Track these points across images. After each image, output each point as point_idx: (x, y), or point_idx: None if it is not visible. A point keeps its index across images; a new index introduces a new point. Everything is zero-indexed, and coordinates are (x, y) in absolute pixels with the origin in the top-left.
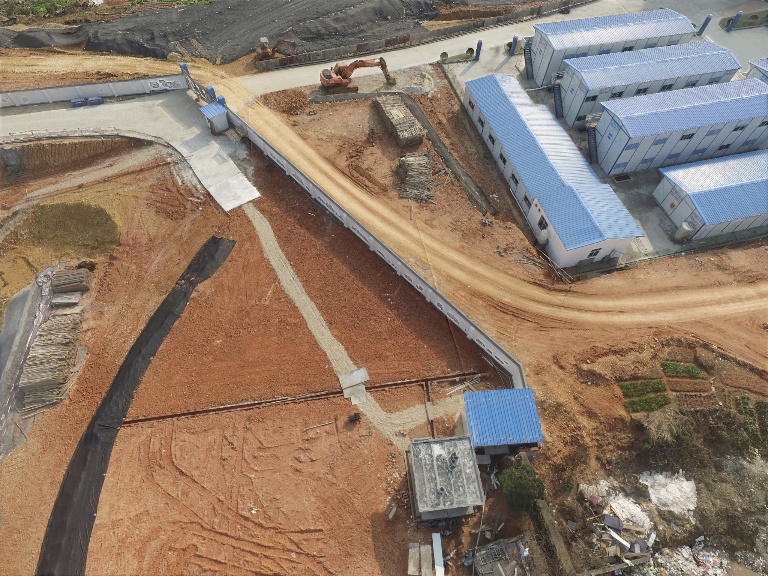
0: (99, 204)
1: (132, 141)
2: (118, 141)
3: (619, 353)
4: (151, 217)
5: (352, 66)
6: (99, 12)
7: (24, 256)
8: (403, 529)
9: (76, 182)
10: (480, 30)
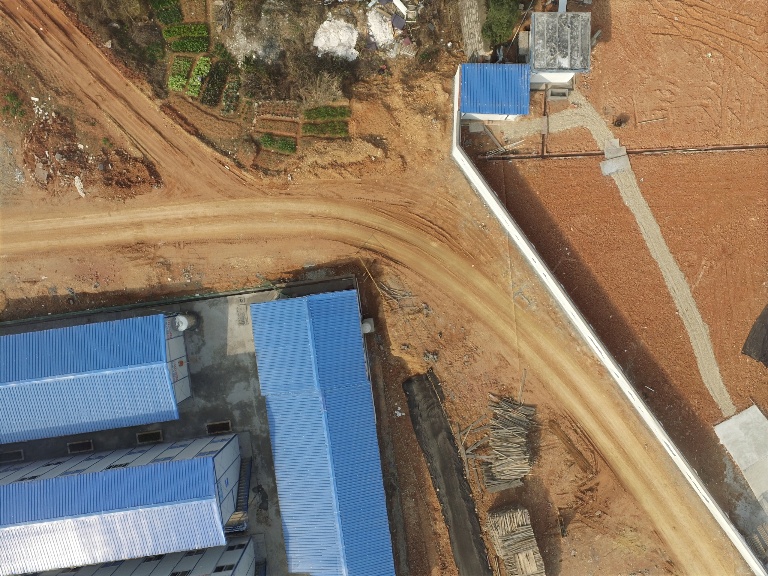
0: None
1: None
2: None
3: (337, 165)
4: None
5: None
6: None
7: None
8: None
9: None
10: None
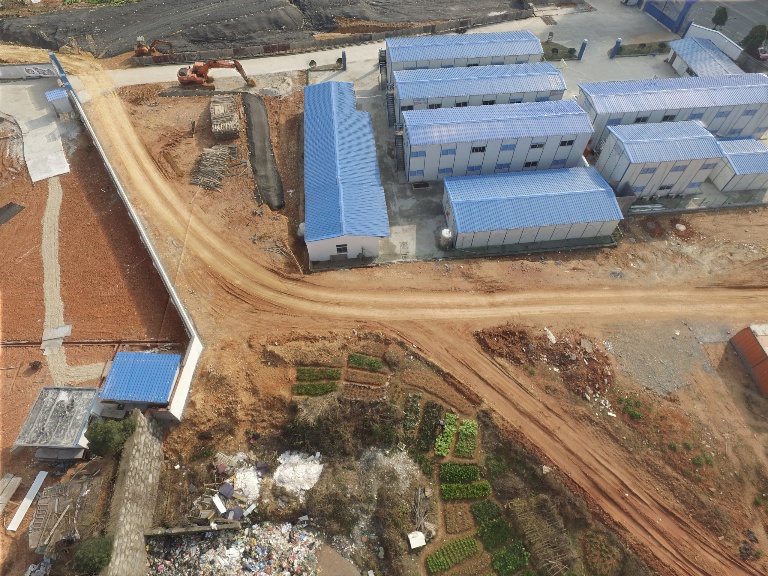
0: None
1: None
2: None
3: (310, 340)
4: None
5: (206, 66)
6: (31, 9)
7: None
8: (23, 465)
9: None
10: (366, 43)
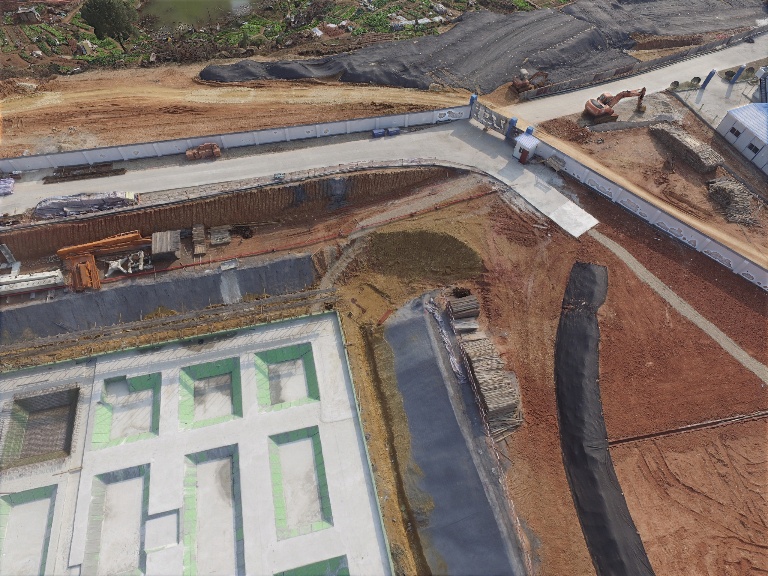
0: (446, 232)
1: (447, 170)
2: (435, 170)
3: None
4: (506, 244)
5: (620, 96)
6: (326, 43)
7: (369, 283)
8: None
9: (405, 210)
10: (686, 59)
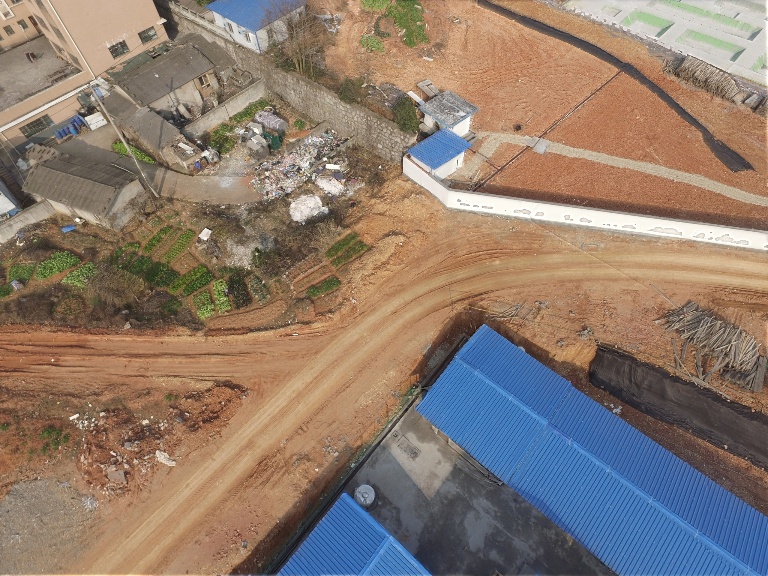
0: None
1: None
2: None
3: (380, 266)
4: None
5: None
6: None
7: None
8: None
9: None
10: None
